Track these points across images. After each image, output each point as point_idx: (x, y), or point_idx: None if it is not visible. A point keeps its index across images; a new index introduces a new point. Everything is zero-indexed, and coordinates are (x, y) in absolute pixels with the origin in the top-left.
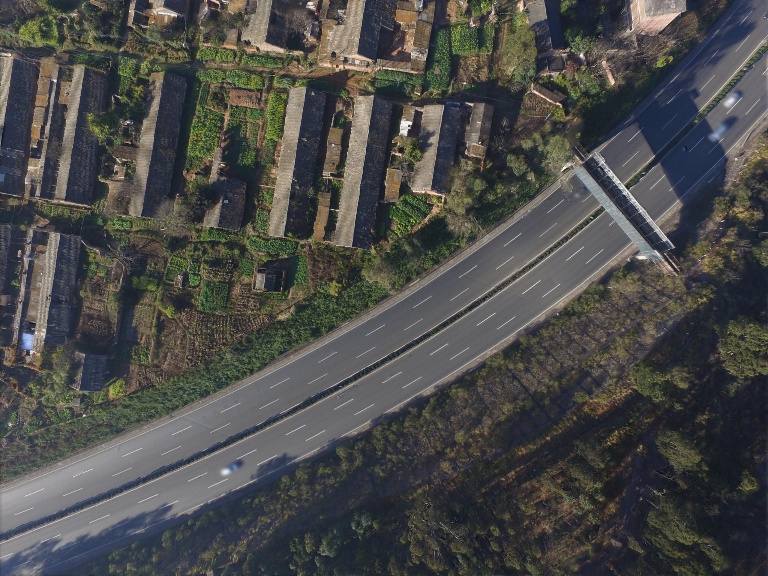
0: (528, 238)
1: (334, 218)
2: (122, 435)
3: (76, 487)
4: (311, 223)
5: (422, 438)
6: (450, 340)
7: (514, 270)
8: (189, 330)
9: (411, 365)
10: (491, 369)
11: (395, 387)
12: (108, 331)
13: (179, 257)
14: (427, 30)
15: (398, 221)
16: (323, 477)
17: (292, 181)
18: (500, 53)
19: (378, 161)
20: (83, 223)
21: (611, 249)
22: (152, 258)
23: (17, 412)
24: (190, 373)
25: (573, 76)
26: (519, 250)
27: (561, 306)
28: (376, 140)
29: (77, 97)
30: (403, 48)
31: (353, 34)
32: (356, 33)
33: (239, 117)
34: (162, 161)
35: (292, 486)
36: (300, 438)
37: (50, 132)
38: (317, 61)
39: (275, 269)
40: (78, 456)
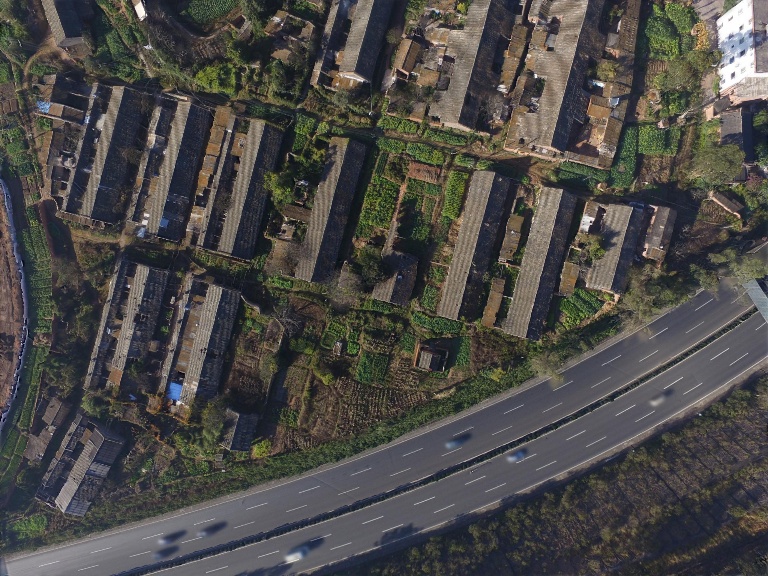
0: (674, 333)
1: (505, 305)
2: (249, 488)
3: (196, 535)
4: (481, 307)
5: (562, 528)
6: (588, 427)
7: (657, 364)
8: (343, 398)
9: (546, 448)
10: (632, 464)
11: (528, 468)
12: (259, 390)
13: (338, 323)
14: (617, 127)
15: (567, 314)
16: (456, 555)
17: (471, 265)
18: (682, 156)
19: (558, 254)
20: (242, 277)
21: (755, 354)
22: (310, 321)
23: (153, 459)
24: (339, 441)
25: (754, 188)
26: (664, 344)
27: (701, 405)
28: (559, 233)
29: (253, 152)
30: (588, 141)
31: (547, 125)
32: (551, 125)
33: (416, 191)
34: (336, 227)
35: (424, 561)
36: (428, 509)
37: (220, 182)
38: (501, 144)
39: (438, 348)
40: (201, 504)
